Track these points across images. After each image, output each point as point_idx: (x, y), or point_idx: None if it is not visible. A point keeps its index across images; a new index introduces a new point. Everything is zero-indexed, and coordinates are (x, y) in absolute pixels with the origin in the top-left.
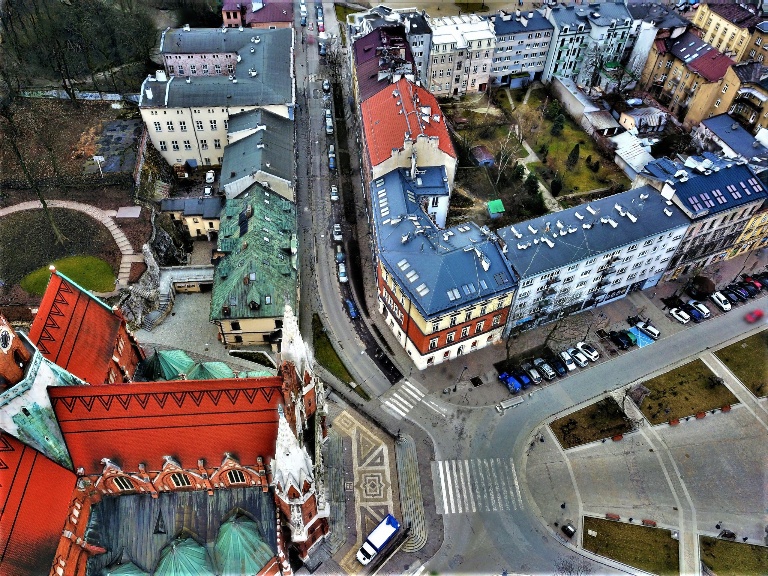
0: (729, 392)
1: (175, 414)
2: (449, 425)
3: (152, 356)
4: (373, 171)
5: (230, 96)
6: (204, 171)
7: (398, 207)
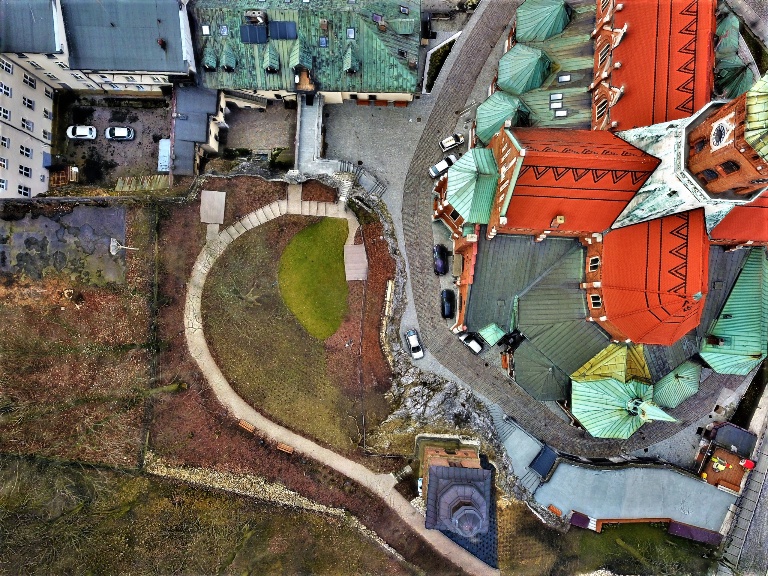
0: None
1: (712, 7)
2: None
3: (513, 120)
4: None
5: None
6: (63, 145)
7: None
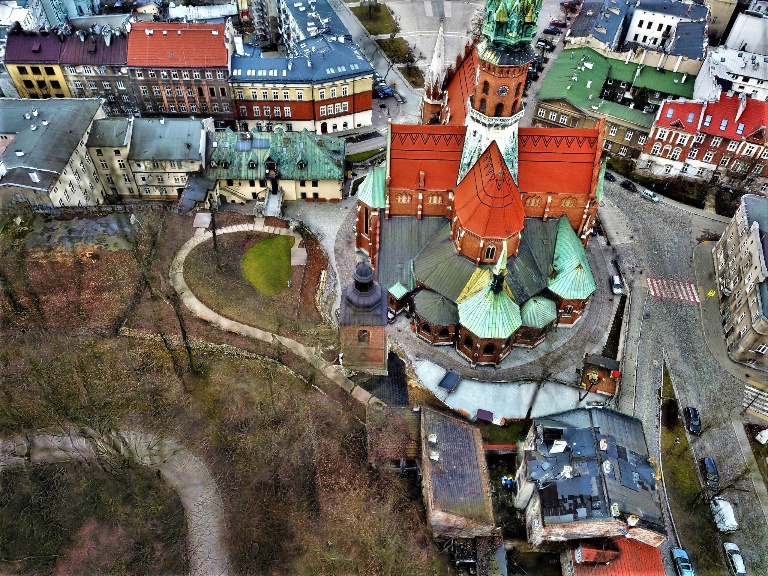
0: (396, 38)
1: None
2: (412, 119)
3: None
4: (228, 69)
5: (69, 130)
6: None
7: (277, 62)
